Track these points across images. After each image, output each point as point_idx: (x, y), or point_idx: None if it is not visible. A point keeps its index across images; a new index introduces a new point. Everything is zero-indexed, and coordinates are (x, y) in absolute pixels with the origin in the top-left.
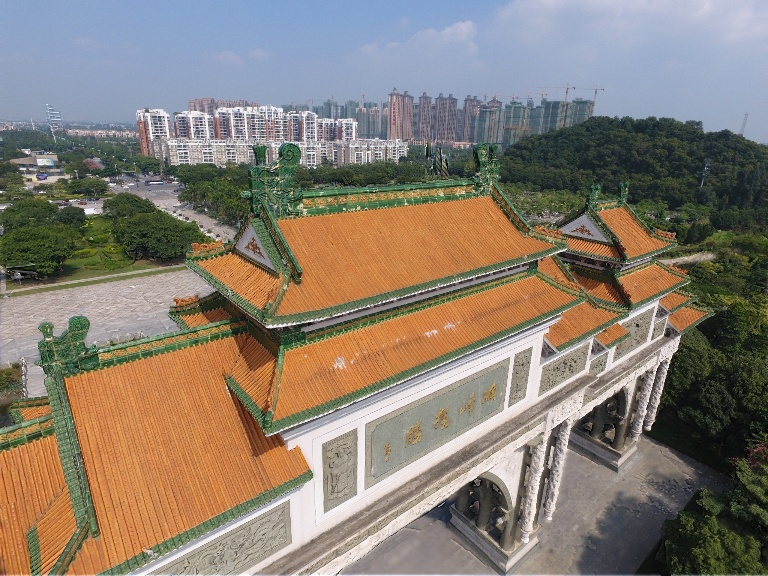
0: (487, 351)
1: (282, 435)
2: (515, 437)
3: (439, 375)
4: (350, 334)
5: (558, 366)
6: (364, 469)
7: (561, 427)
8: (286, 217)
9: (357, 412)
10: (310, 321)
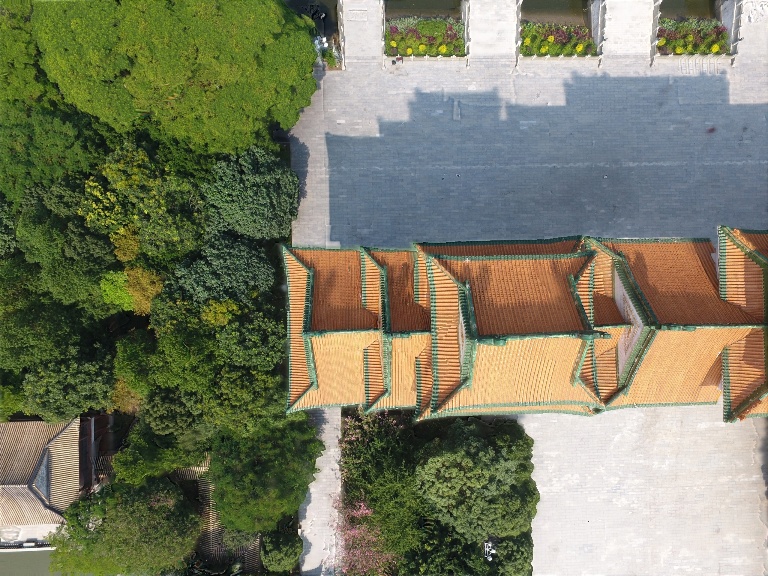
0: None
1: None
2: None
3: None
4: None
5: None
6: None
7: None
8: None
9: None
10: None
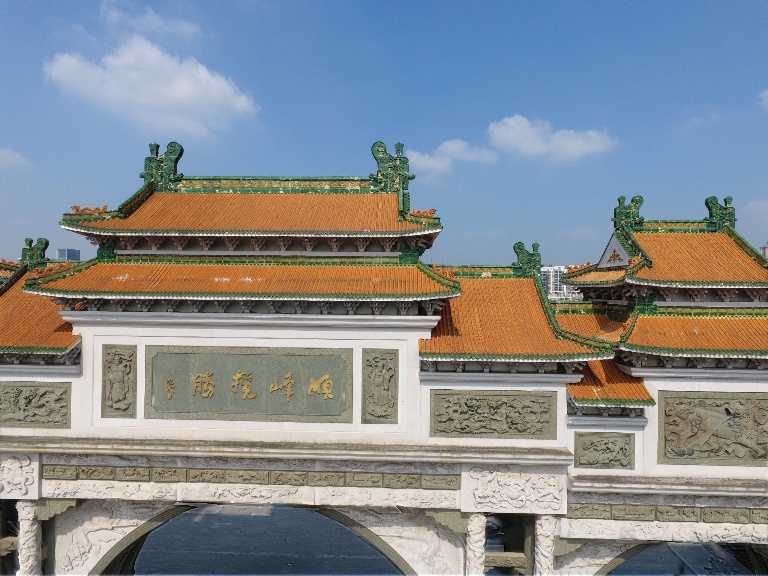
0: (296, 321)
1: (58, 311)
2: (390, 482)
3: (234, 329)
4: (154, 266)
5: (467, 401)
6: (144, 394)
7: (534, 538)
8: (168, 192)
9: (136, 328)
10: (97, 233)
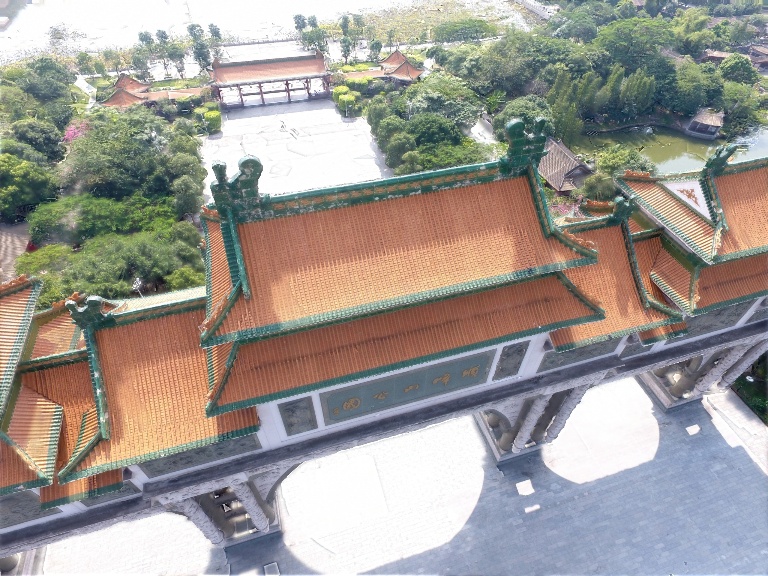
0: None
1: None
2: None
3: None
4: None
5: None
6: None
7: None
8: None
9: None
10: None
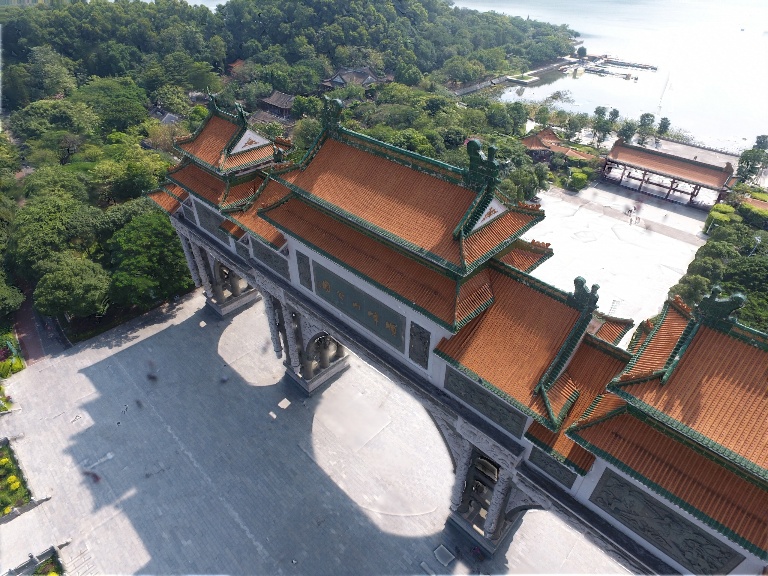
0: None
1: None
2: None
3: None
4: None
5: None
6: None
7: None
8: None
9: None
10: None
